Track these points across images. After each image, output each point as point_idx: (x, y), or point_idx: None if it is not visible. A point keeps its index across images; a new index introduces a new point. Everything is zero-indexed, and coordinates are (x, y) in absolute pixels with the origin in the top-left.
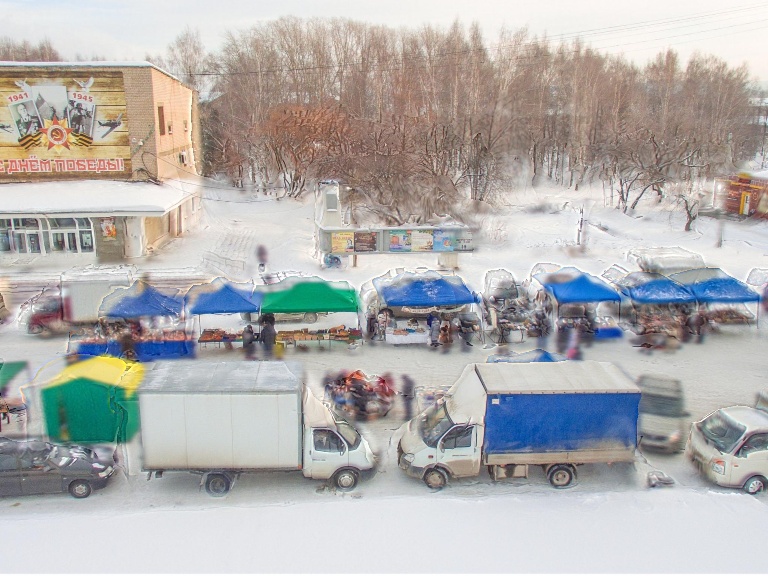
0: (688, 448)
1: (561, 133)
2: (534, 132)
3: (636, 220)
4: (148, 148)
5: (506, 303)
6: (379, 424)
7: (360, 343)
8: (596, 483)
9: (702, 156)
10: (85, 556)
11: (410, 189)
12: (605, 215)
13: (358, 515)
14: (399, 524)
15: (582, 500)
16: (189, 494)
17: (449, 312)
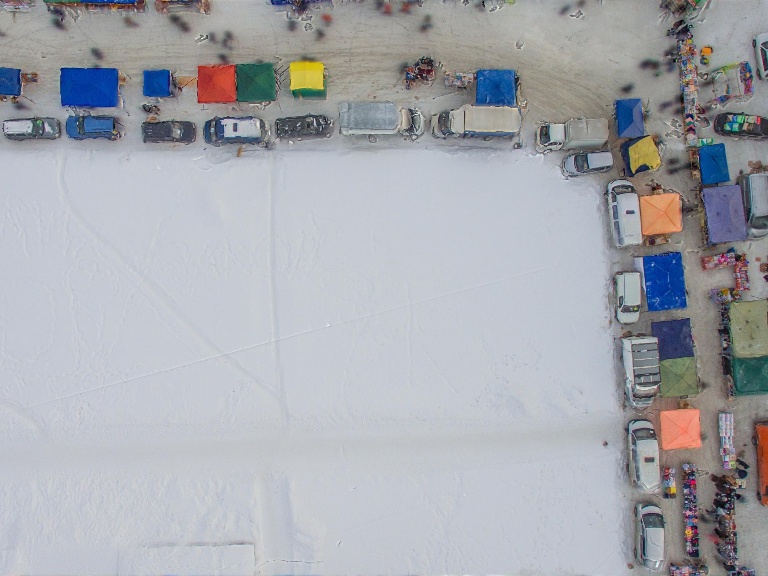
0: None
1: None
2: None
3: None
4: None
5: None
6: (428, 94)
7: None
8: (497, 143)
9: None
10: (342, 170)
11: None
12: None
13: (418, 157)
14: (430, 161)
15: (488, 156)
16: (364, 141)
17: None
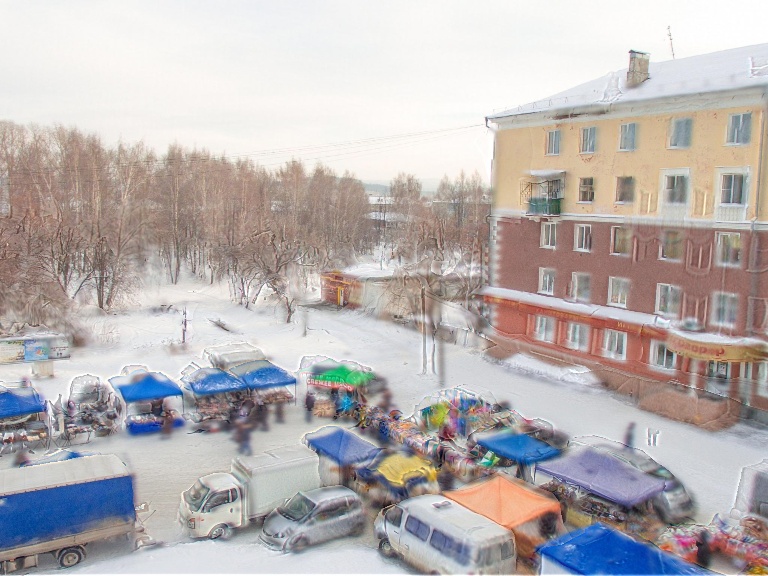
0: (178, 513)
1: (201, 233)
2: (177, 231)
3: (248, 315)
4: None
5: (81, 408)
6: None
7: None
8: (92, 557)
9: (330, 252)
10: None
11: (12, 297)
12: (229, 310)
13: None
14: None
15: (67, 574)
16: None
17: (14, 424)
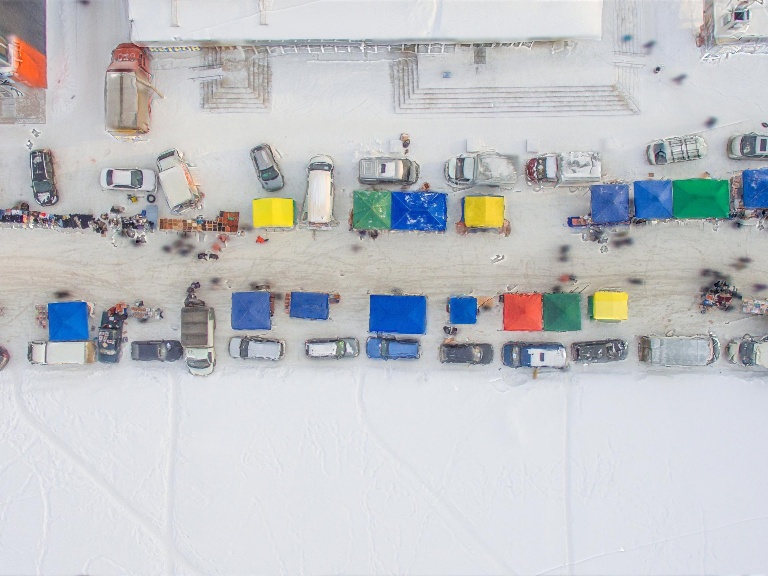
0: None
1: None
2: None
3: None
4: None
5: None
6: (723, 318)
7: (720, 223)
8: None
9: None
10: None
11: None
12: None
13: (713, 382)
14: (725, 387)
15: None
16: None
17: None
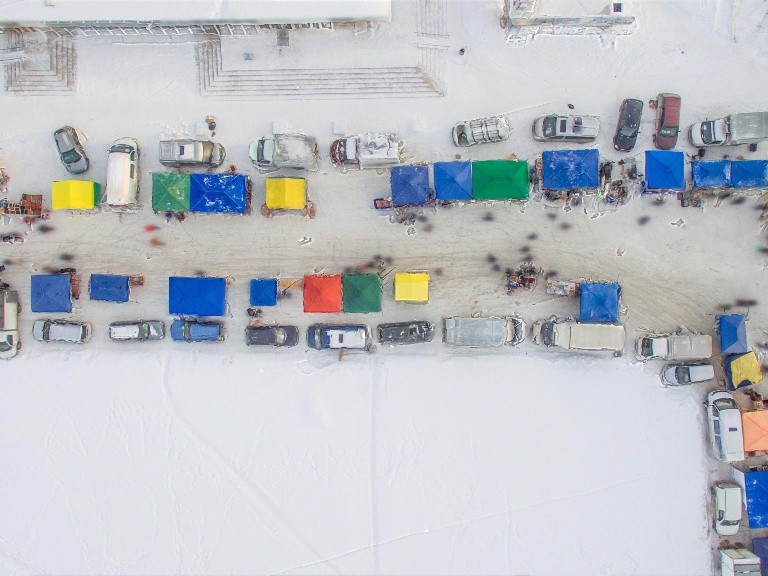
0: None
1: None
2: None
3: None
4: None
5: (621, 166)
6: (529, 300)
7: (527, 205)
8: None
9: None
10: None
11: None
12: None
13: (518, 363)
14: (530, 368)
15: (588, 364)
16: None
17: None
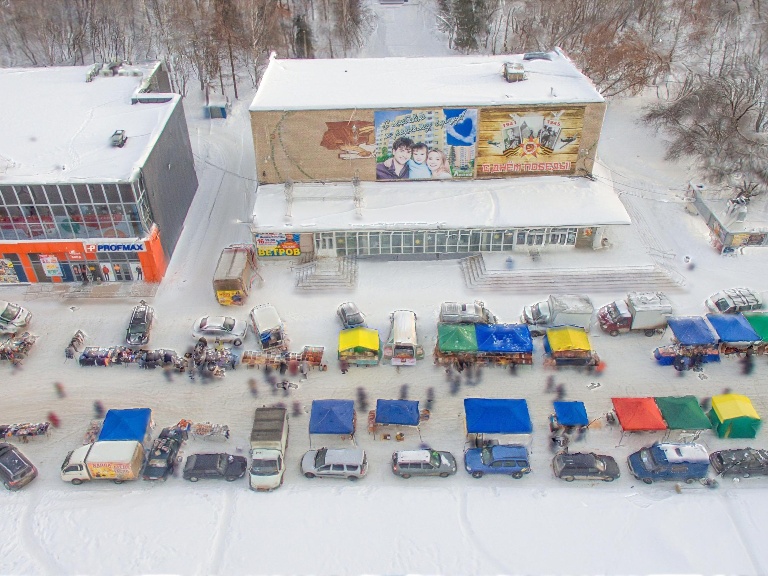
0: None
1: None
2: None
3: None
4: (590, 155)
5: None
6: None
7: None
8: None
9: None
10: None
11: (755, 164)
12: None
13: None
14: None
15: None
16: None
17: None
